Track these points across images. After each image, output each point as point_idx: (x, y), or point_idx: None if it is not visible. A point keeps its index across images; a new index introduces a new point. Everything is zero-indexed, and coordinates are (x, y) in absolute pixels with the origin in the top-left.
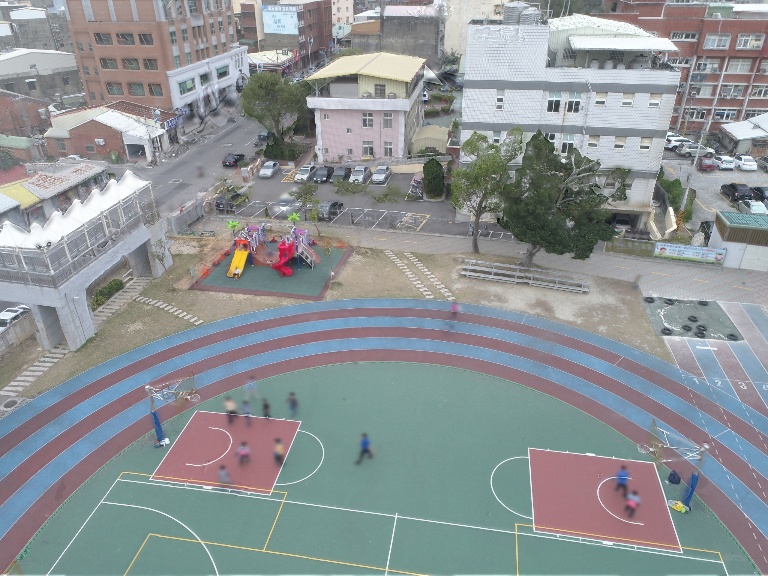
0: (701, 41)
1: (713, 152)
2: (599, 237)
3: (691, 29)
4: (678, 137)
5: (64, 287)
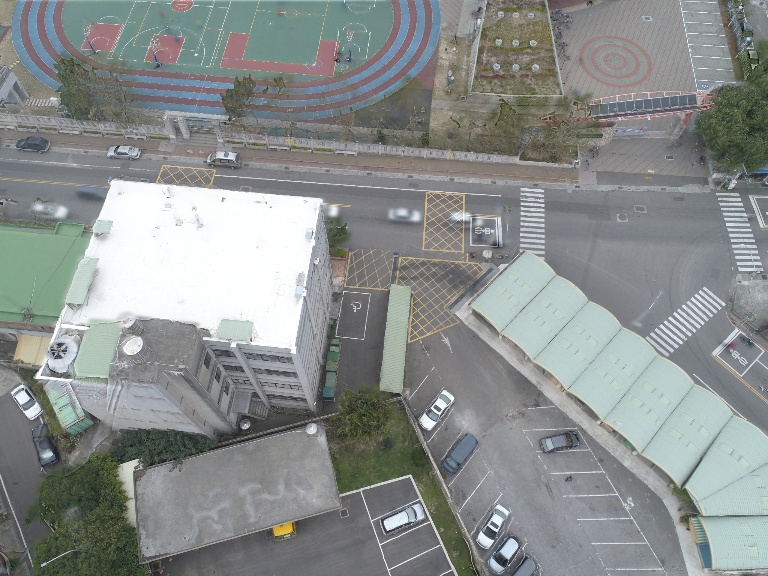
0: None
1: None
2: None
3: None
4: None
5: None
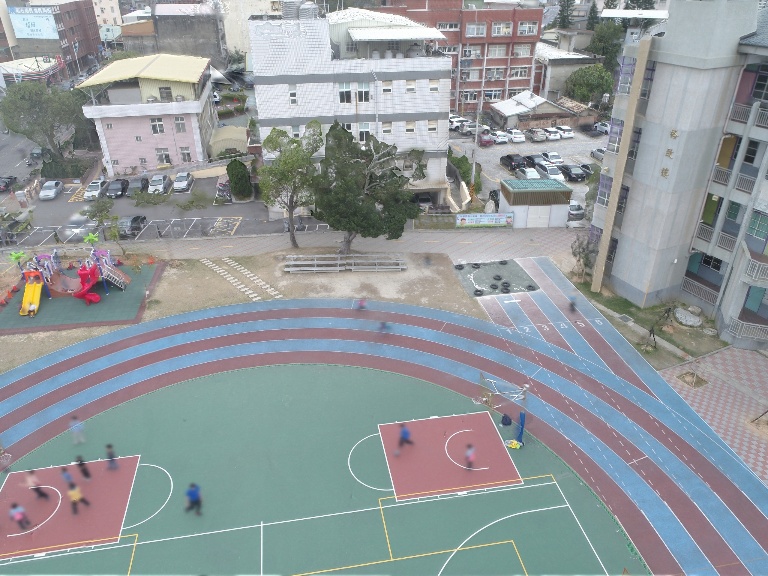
0: (463, 30)
1: (489, 129)
2: (407, 216)
3: (453, 20)
4: (458, 118)
5: None
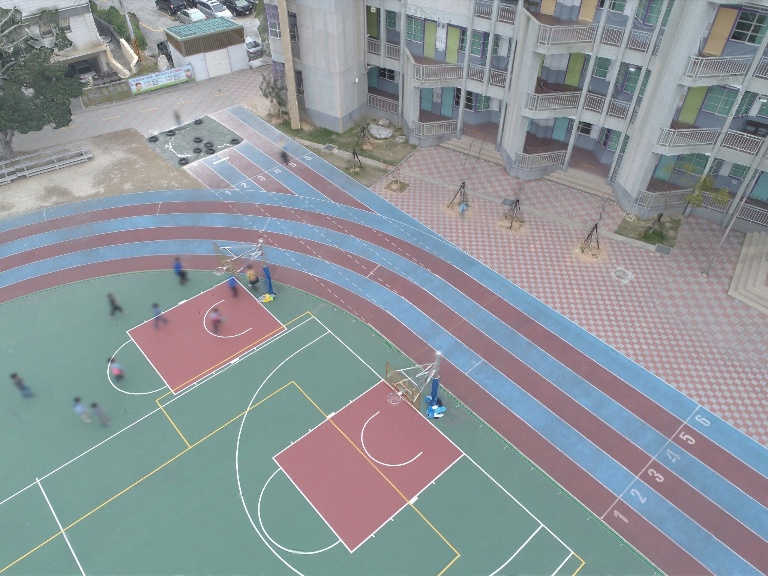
0: None
1: None
2: (69, 95)
3: None
4: None
5: None
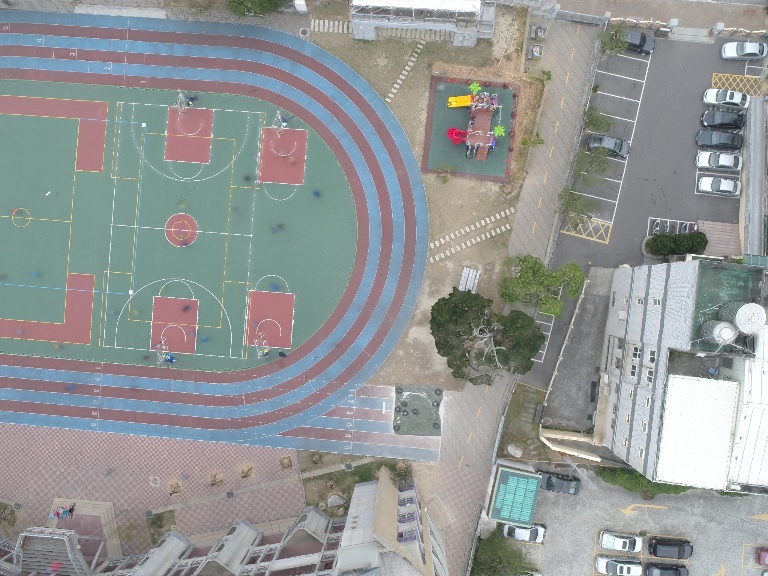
0: None
1: None
2: None
3: None
4: None
5: (356, 21)
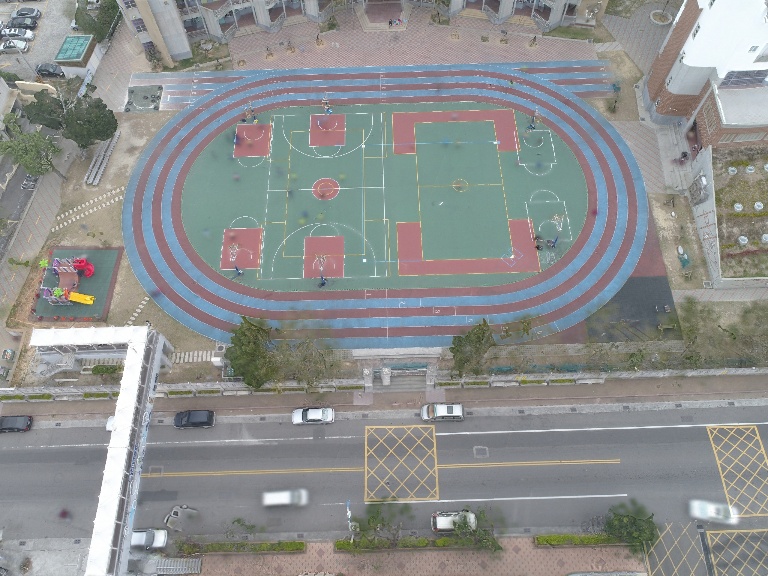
0: None
1: None
2: None
3: None
4: None
5: None
